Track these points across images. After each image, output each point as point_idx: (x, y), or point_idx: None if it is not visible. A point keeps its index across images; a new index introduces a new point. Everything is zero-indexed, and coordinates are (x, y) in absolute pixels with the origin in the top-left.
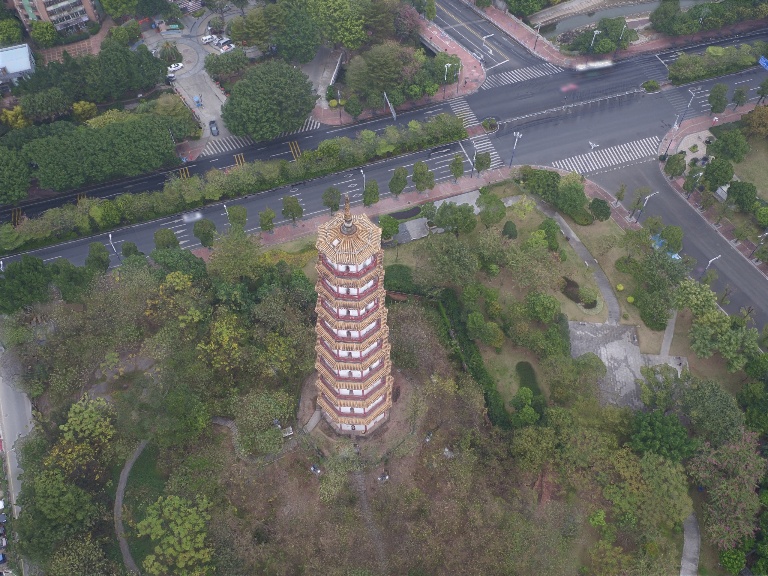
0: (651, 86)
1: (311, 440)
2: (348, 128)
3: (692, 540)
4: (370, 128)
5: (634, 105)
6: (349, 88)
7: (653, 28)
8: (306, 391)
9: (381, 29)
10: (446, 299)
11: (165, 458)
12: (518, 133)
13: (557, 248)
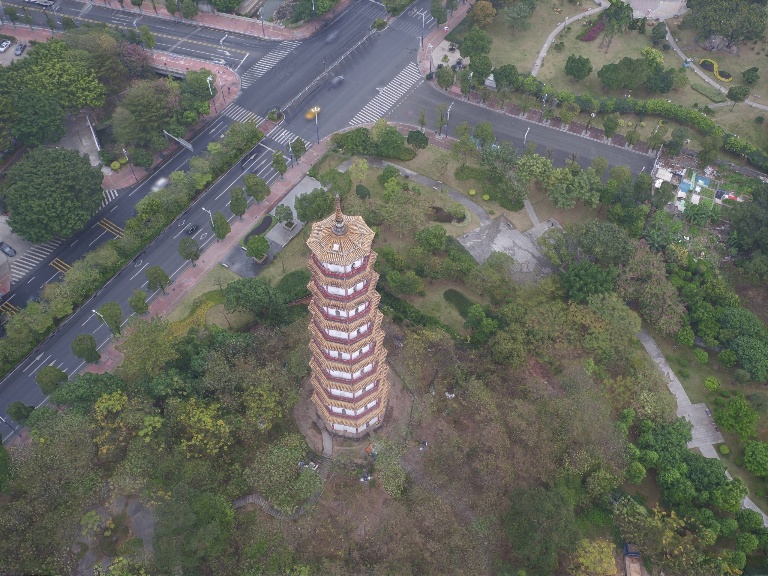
0: (380, 24)
1: (347, 456)
2: (147, 181)
3: (648, 342)
4: (168, 171)
5: (377, 45)
6: (117, 145)
7: None
8: (301, 424)
9: (115, 75)
10: None
11: (219, 568)
12: (315, 108)
13: None
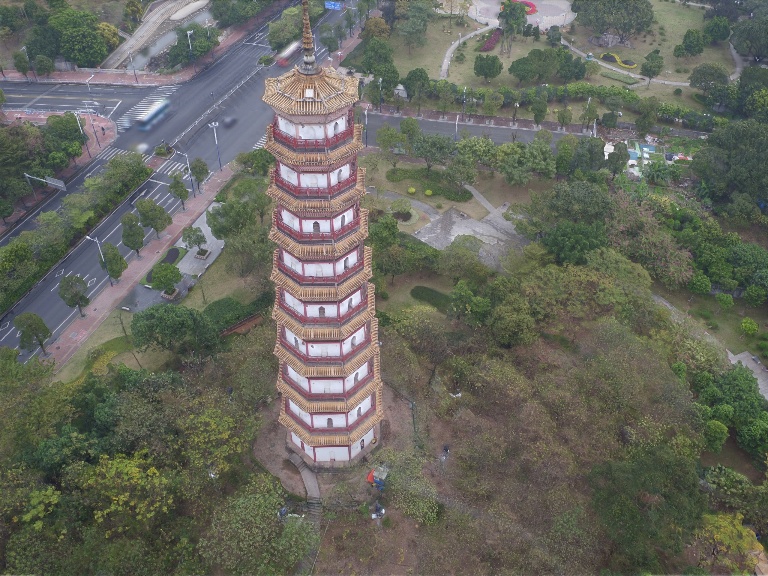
0: (267, 60)
1: (347, 484)
2: (8, 236)
3: None
4: None
5: None
6: None
7: (219, 28)
8: (267, 467)
9: None
10: None
11: None
12: (213, 123)
13: None
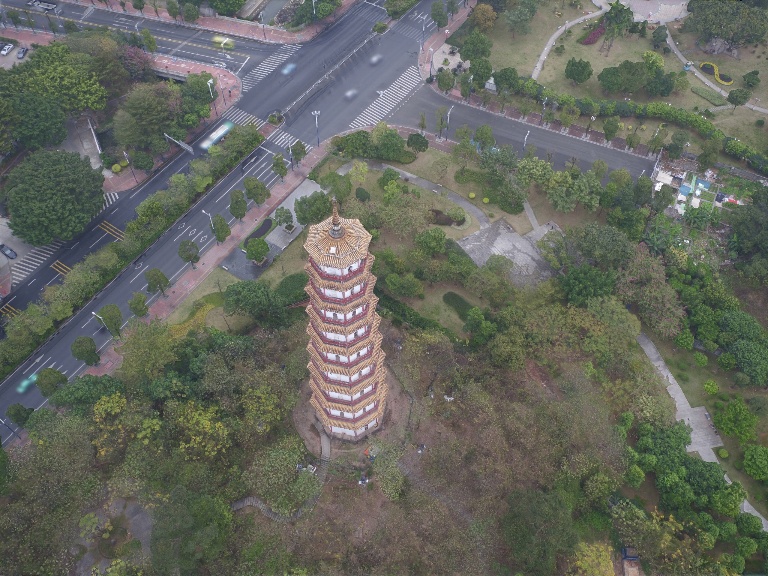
0: (381, 27)
1: (345, 459)
2: (148, 184)
3: (648, 346)
4: (169, 174)
5: (378, 49)
6: (118, 148)
7: None
8: (299, 426)
9: (117, 78)
10: None
11: (217, 571)
12: (315, 111)
13: (407, 190)
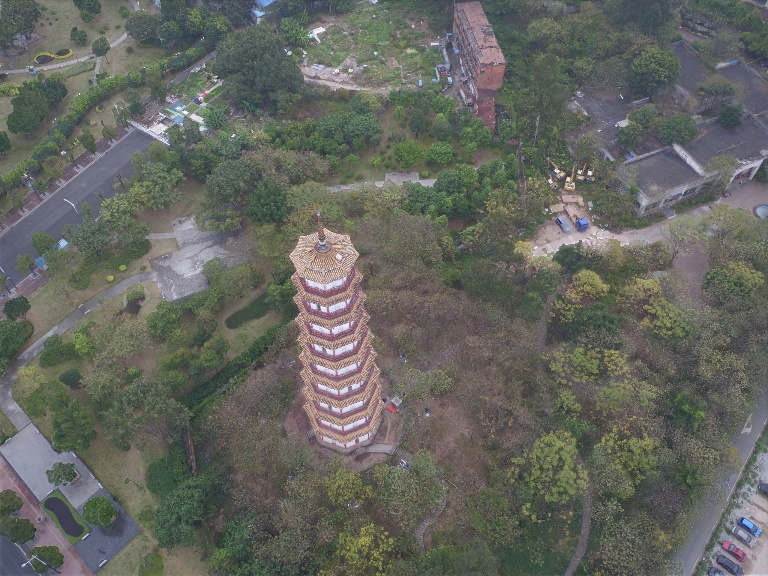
0: None
1: None
2: None
3: None
4: None
5: None
6: None
7: None
8: None
9: None
10: None
11: None
12: None
13: None
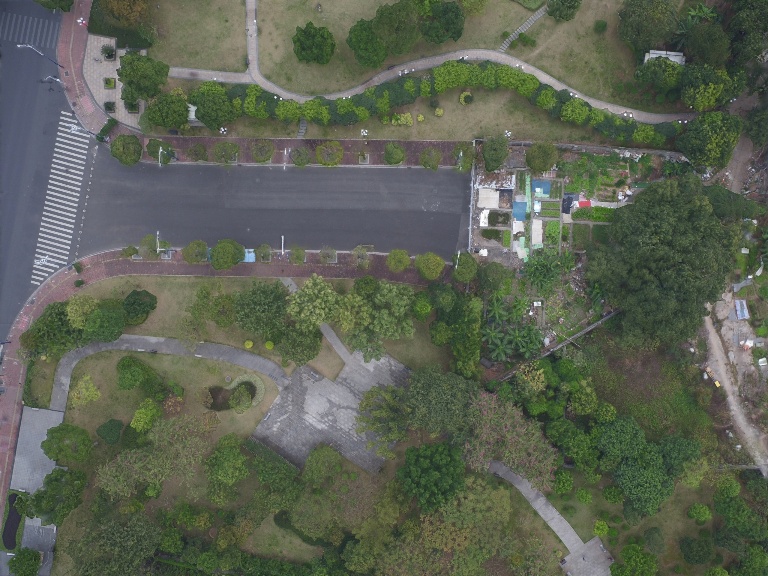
0: None
1: None
2: None
3: (523, 483)
4: None
5: None
6: None
7: None
8: None
9: None
10: (158, 549)
11: None
12: None
13: (163, 388)
